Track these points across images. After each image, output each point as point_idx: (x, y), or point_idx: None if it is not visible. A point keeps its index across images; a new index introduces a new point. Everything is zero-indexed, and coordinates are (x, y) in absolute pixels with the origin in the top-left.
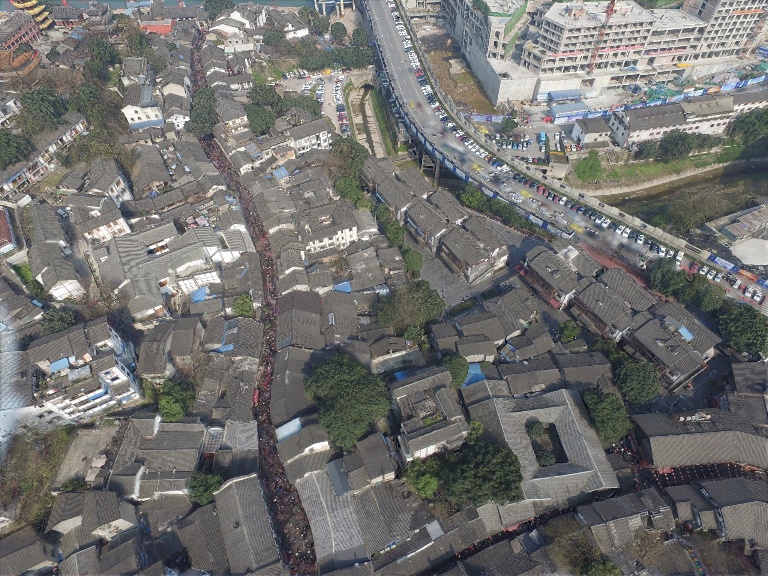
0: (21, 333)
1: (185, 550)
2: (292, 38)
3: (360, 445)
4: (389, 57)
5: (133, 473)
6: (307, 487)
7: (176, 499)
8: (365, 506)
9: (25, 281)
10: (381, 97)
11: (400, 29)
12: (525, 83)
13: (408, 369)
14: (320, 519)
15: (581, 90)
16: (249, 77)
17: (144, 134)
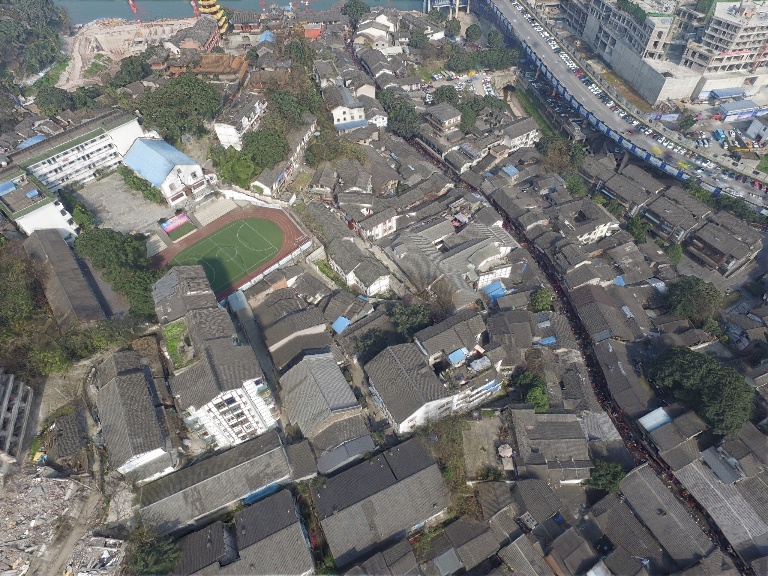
0: (366, 327)
1: (605, 538)
2: (430, 41)
3: (739, 433)
4: (541, 58)
5: (543, 462)
6: (689, 475)
7: (571, 488)
8: (755, 493)
9: (328, 277)
10: (532, 97)
11: (540, 31)
12: (688, 82)
13: None
14: (719, 506)
15: (742, 88)
16: (419, 79)
17: (361, 134)
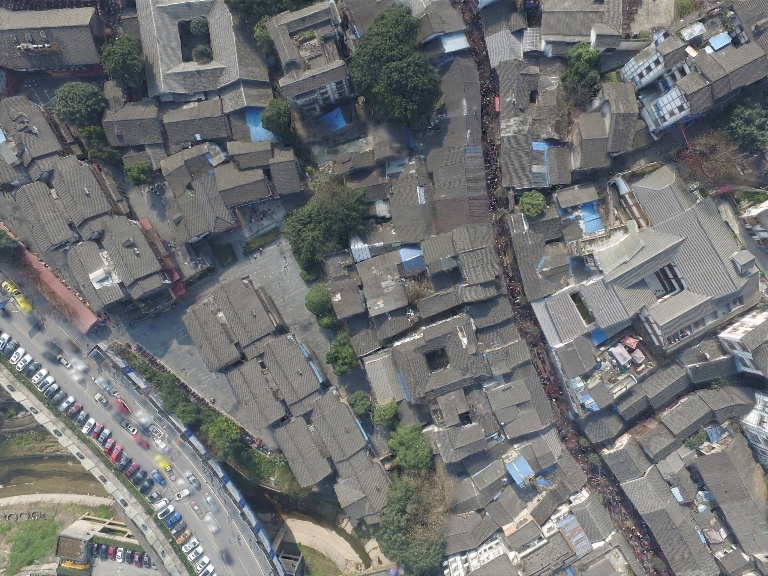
0: None
1: None
2: None
3: None
4: None
5: None
6: None
7: None
8: None
9: None
10: None
11: None
12: None
13: (333, 146)
14: None
15: None
16: None
17: None
